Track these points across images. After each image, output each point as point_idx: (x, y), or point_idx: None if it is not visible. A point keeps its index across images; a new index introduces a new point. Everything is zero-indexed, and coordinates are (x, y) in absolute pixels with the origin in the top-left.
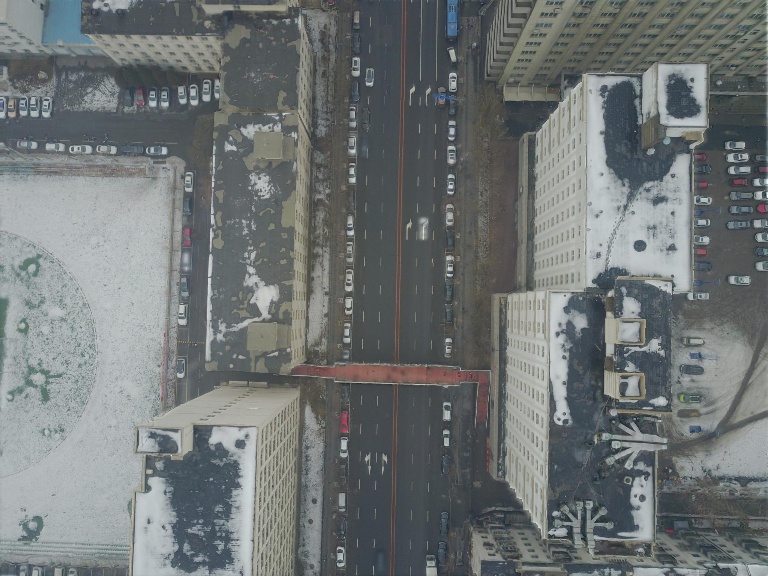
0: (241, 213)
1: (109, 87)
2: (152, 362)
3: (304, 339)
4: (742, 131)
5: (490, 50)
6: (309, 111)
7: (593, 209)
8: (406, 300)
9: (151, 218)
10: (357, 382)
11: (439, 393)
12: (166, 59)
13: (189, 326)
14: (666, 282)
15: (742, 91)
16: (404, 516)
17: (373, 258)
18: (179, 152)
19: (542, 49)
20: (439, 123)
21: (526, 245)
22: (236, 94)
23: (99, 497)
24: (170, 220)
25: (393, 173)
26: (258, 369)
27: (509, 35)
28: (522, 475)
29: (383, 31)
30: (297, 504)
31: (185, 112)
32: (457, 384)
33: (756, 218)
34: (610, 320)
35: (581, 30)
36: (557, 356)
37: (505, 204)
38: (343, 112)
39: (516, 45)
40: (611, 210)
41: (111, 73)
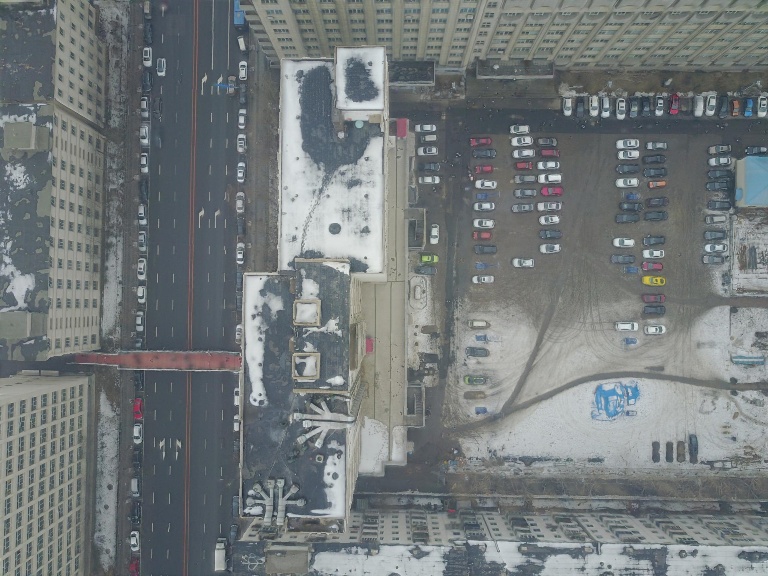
0: None
1: None
2: None
3: (98, 328)
4: (528, 115)
5: None
6: (98, 102)
7: (289, 193)
8: (199, 288)
9: None
10: (139, 369)
11: (231, 379)
12: None
13: None
14: (343, 263)
15: (518, 75)
16: (198, 500)
17: (167, 247)
18: None
19: (294, 36)
20: (231, 112)
21: None
22: None
23: None
24: None
25: (186, 162)
26: (15, 357)
27: (254, 22)
28: None
29: (176, 21)
30: (93, 490)
31: None
32: (237, 369)
33: (541, 201)
34: None
35: (314, 16)
36: (253, 338)
37: None
38: (136, 102)
39: (266, 32)
40: (306, 194)
41: None
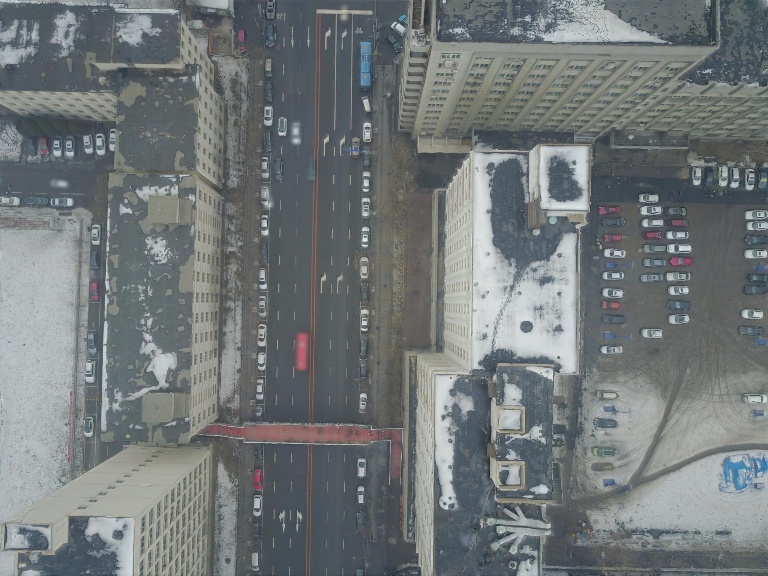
0: (137, 278)
1: (11, 136)
2: (59, 421)
3: (216, 396)
4: (656, 183)
5: (401, 103)
6: (219, 162)
7: (479, 289)
8: (320, 355)
9: (57, 272)
10: (267, 442)
11: (354, 449)
12: (67, 110)
13: (97, 383)
14: (547, 368)
15: (653, 145)
16: (319, 574)
17: (287, 312)
18: (85, 204)
19: (446, 109)
20: (354, 174)
21: (436, 303)
22: (131, 155)
23: (4, 561)
24: (76, 274)
25: (307, 225)
26: (155, 439)
27: (410, 97)
28: (421, 547)
29: (297, 79)
30: (210, 564)
31: (92, 162)
32: (368, 443)
33: (669, 271)
34: (494, 405)
35: (479, 96)
36: (443, 440)
37: (420, 257)
38: None
39: (419, 106)
40: (498, 290)
41: (13, 121)
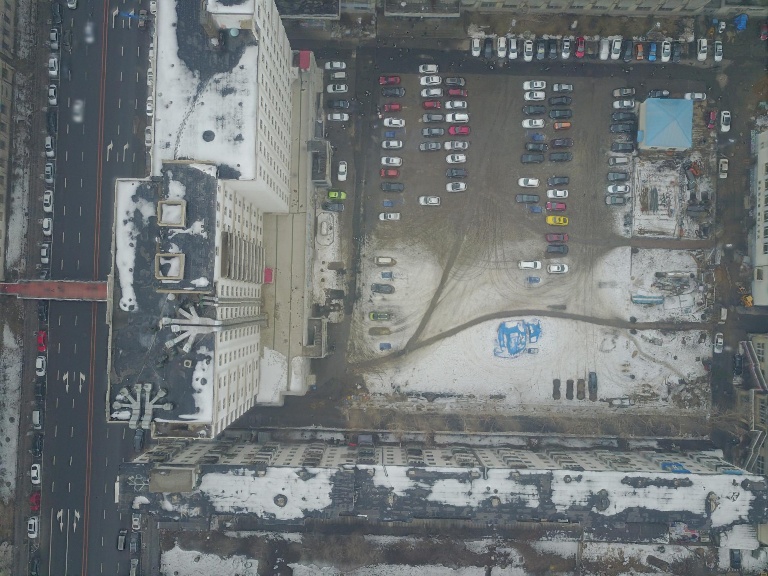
0: None
1: None
2: None
3: (2, 259)
4: (437, 55)
5: None
6: (6, 31)
7: (163, 100)
8: (106, 221)
9: None
10: (40, 298)
11: None
12: None
13: None
14: (210, 166)
15: (425, 12)
16: (101, 434)
17: (74, 180)
18: None
19: None
20: (142, 46)
21: None
22: None
23: None
24: None
25: (96, 95)
26: None
27: None
28: None
29: None
30: None
31: None
32: None
33: (448, 140)
34: None
35: None
36: (124, 244)
37: None
38: (46, 34)
39: None
40: (181, 101)
41: None
